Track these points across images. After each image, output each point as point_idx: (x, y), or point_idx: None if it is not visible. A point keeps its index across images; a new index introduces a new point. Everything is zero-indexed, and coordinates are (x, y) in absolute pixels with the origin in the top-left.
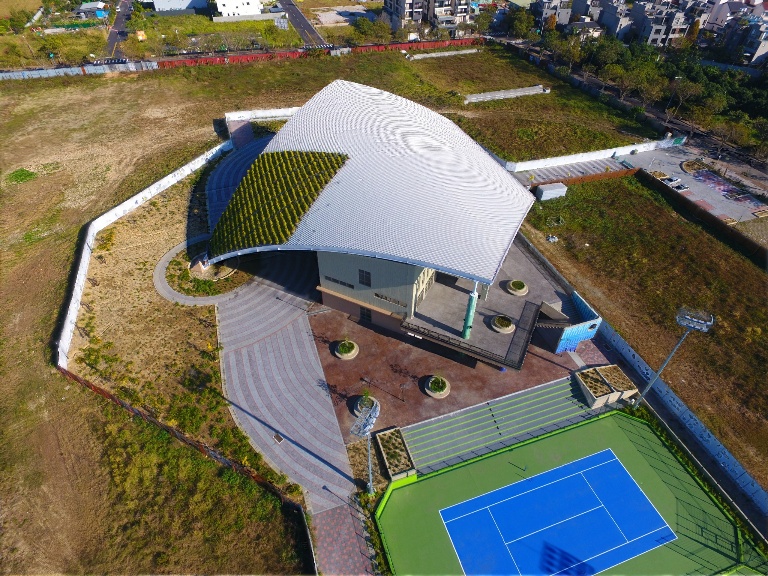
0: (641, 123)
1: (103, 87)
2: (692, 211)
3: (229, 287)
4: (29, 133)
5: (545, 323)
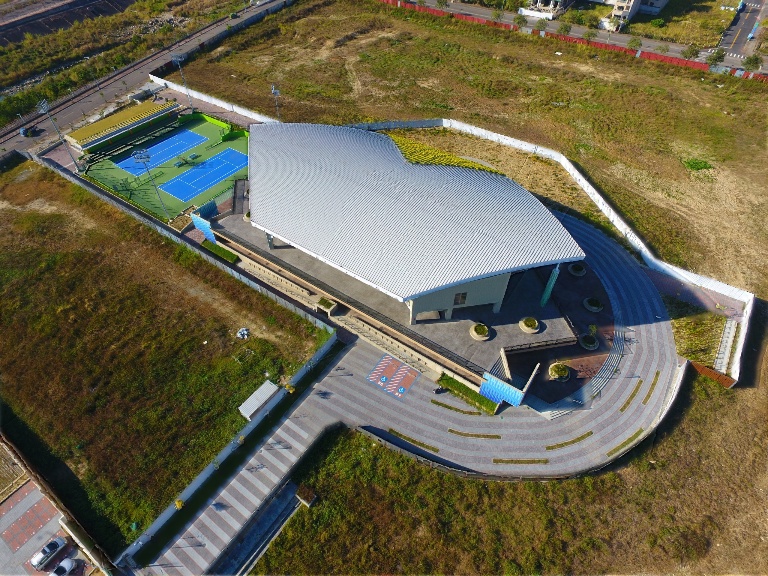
0: None
1: None
2: None
3: None
4: None
5: None
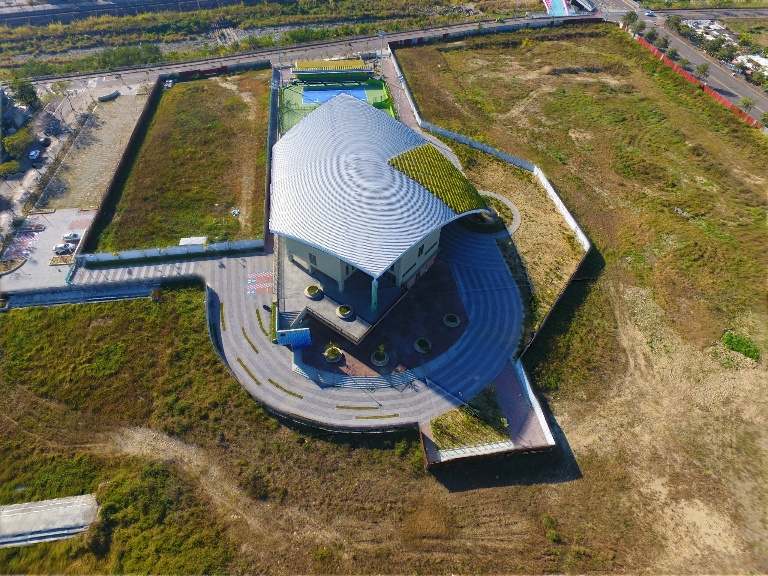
0: None
1: None
2: None
3: None
4: None
5: None
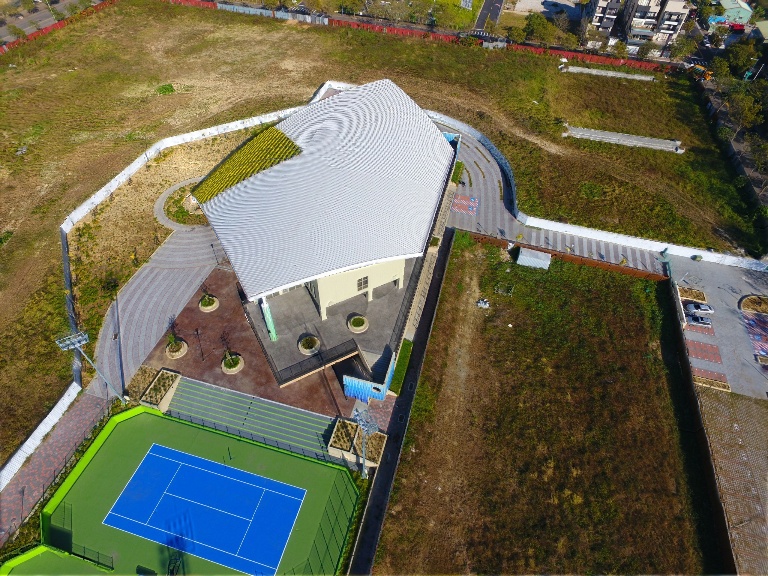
0: (756, 229)
1: (277, 32)
2: (679, 351)
3: (194, 222)
4: (200, 57)
5: (361, 366)
